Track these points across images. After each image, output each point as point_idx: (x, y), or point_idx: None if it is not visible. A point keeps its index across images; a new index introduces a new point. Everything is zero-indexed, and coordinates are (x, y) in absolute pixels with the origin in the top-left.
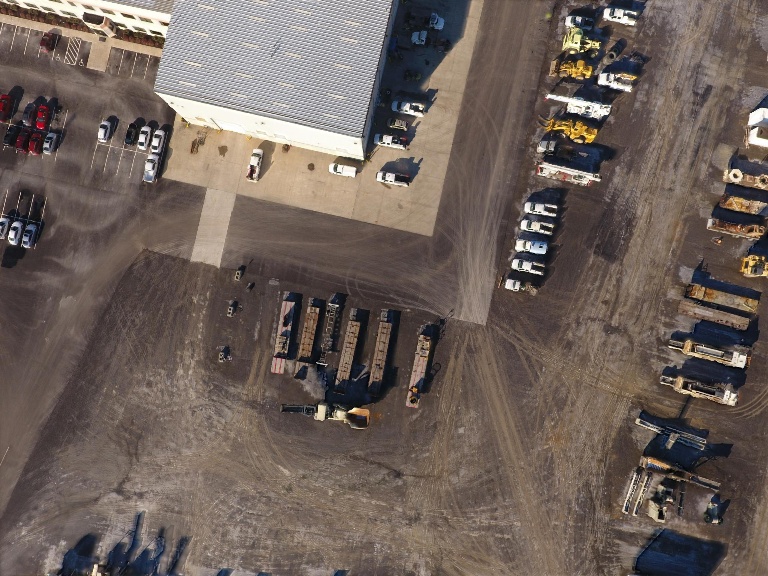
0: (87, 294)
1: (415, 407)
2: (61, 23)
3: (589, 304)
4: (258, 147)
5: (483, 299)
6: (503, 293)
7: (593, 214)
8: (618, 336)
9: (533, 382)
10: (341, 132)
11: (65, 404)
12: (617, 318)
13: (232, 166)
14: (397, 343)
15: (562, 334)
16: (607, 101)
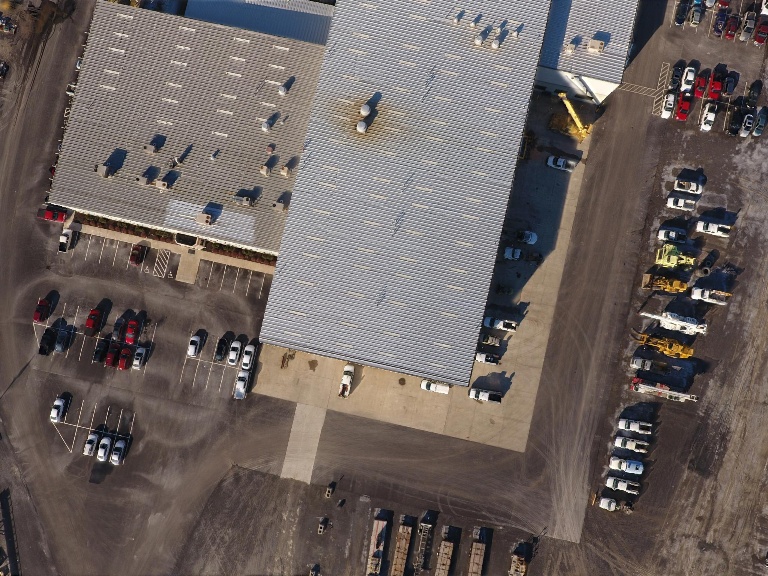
0: (176, 511)
1: None
2: (150, 235)
3: (683, 520)
4: None
5: (576, 516)
6: (597, 510)
7: (687, 428)
8: (713, 553)
9: None
10: (447, 382)
11: None
12: (712, 534)
13: (322, 381)
14: (489, 561)
15: (656, 551)
16: (700, 313)
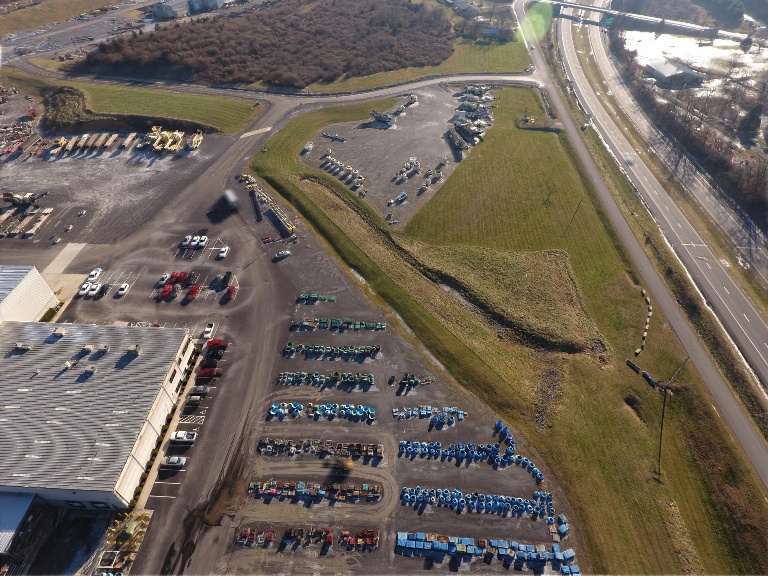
0: (157, 225)
1: None
2: None
3: None
4: None
5: None
6: None
7: None
8: None
9: None
10: None
11: None
12: None
13: None
14: None
15: None
16: None
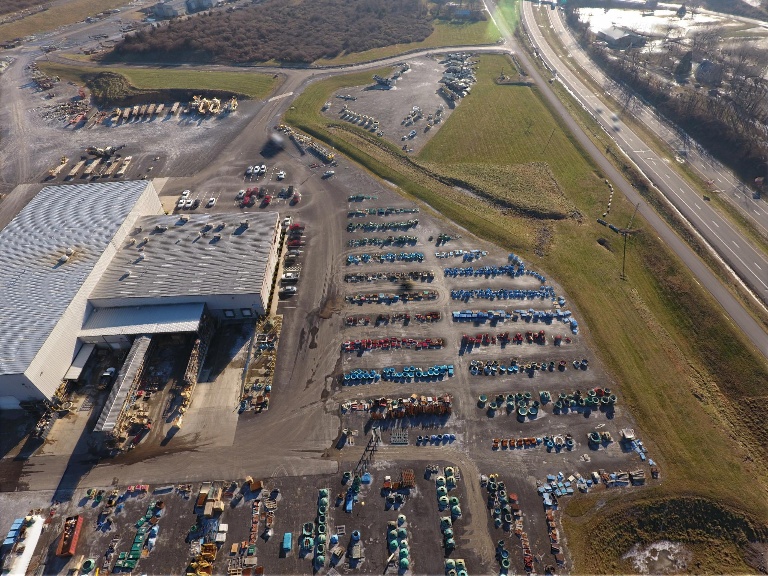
0: (222, 162)
1: None
2: None
3: None
4: None
5: None
6: None
7: None
8: None
9: None
10: (55, 186)
11: None
12: None
13: None
14: None
15: None
16: None
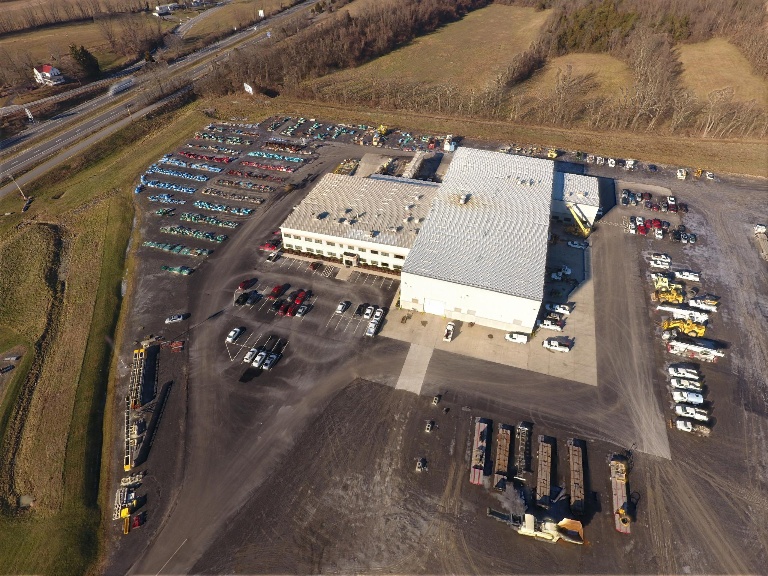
0: (304, 405)
1: (627, 532)
2: (324, 259)
3: (764, 450)
4: None
5: (660, 437)
6: (677, 434)
7: (729, 382)
8: None
9: (745, 521)
10: (527, 298)
11: (258, 499)
12: None
13: (431, 332)
14: (589, 469)
15: (752, 475)
16: None
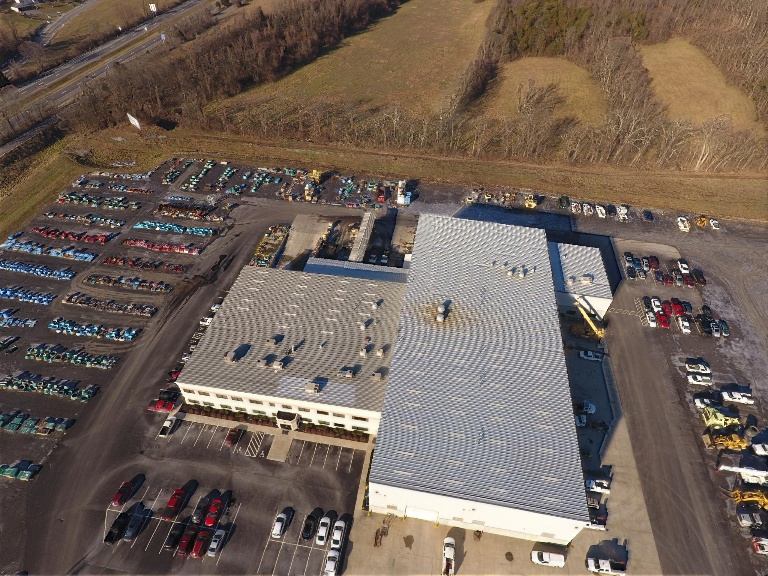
0: None
1: None
2: (248, 420)
3: None
4: (447, 535)
5: None
6: None
7: None
8: None
9: None
10: (567, 516)
11: None
12: None
13: (421, 560)
14: None
15: None
16: None
